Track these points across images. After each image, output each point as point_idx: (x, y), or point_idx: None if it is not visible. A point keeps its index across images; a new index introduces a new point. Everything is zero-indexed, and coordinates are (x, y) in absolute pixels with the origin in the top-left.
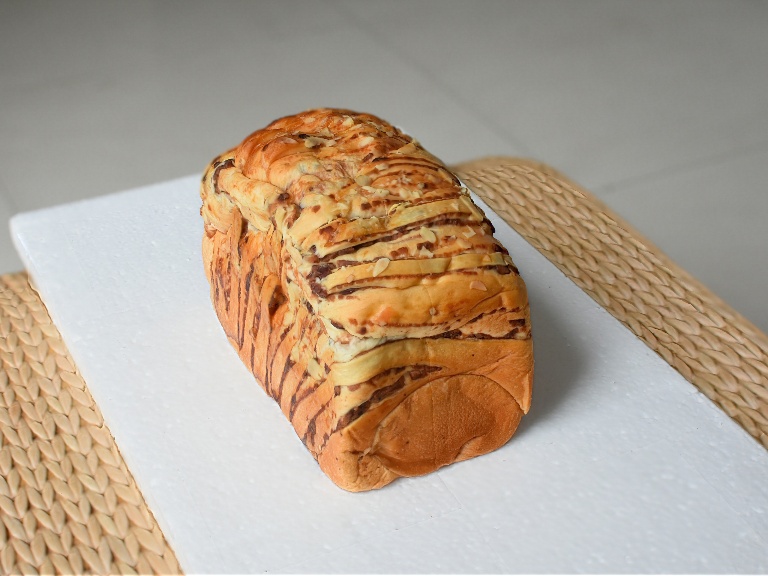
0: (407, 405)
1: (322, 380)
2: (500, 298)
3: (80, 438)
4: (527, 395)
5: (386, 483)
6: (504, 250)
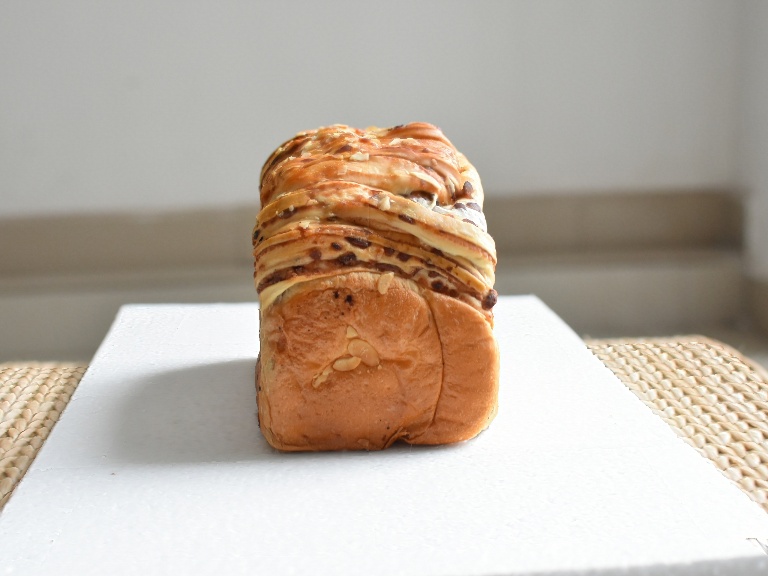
0: None
1: None
2: None
3: None
4: None
5: None
6: None
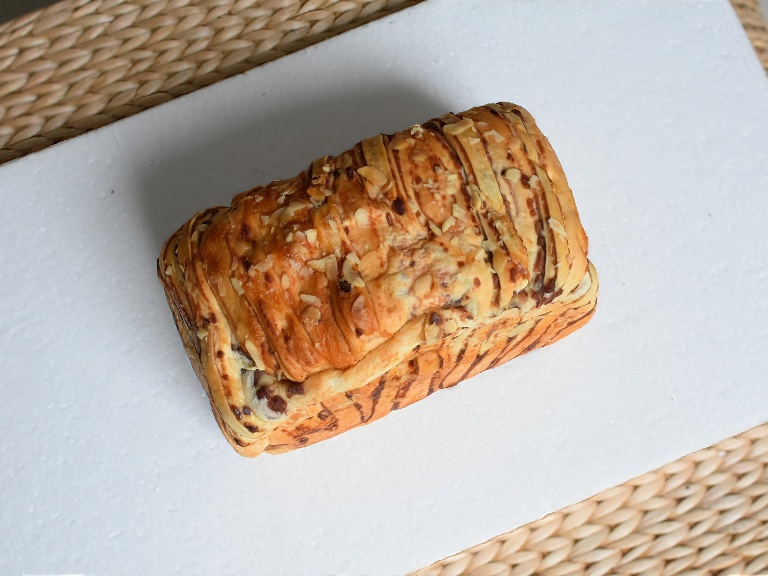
0: None
1: (537, 322)
2: None
3: None
4: None
5: None
6: (490, 109)
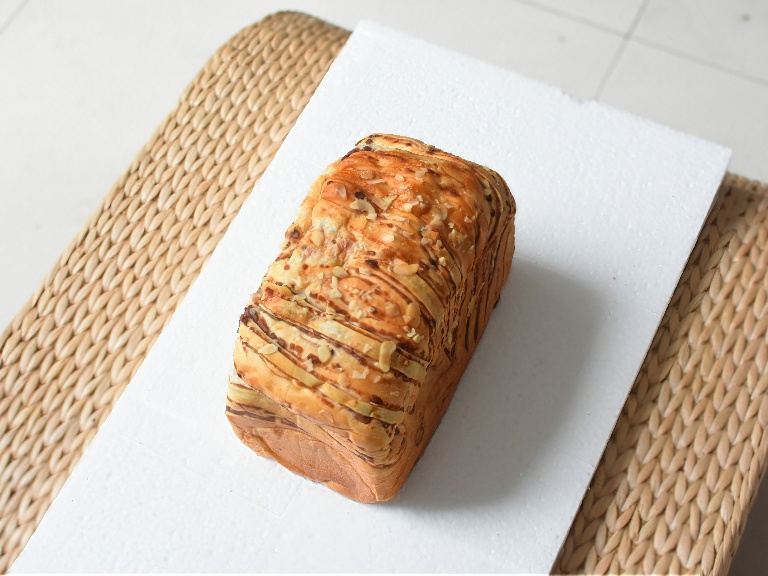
0: (278, 432)
1: None
2: (348, 433)
3: (210, 241)
4: (376, 494)
5: (264, 456)
6: (384, 404)
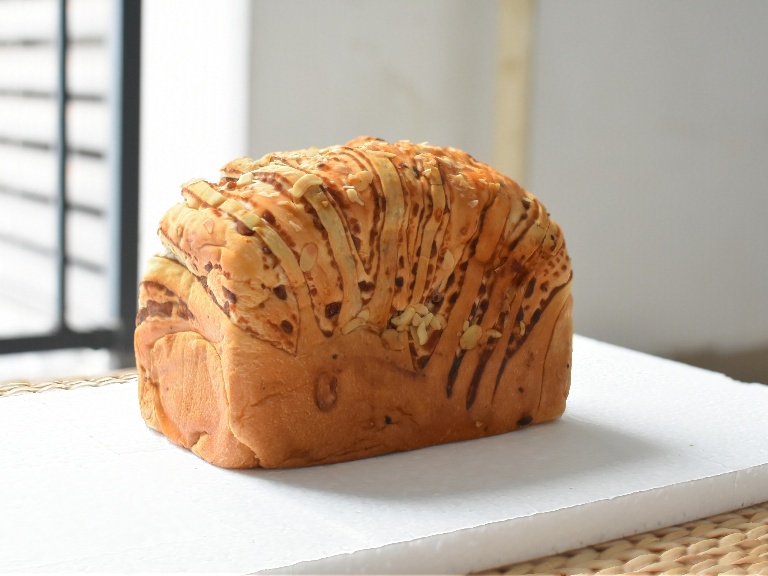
0: (170, 341)
1: None
2: (221, 252)
3: None
4: None
5: None
6: (276, 225)
